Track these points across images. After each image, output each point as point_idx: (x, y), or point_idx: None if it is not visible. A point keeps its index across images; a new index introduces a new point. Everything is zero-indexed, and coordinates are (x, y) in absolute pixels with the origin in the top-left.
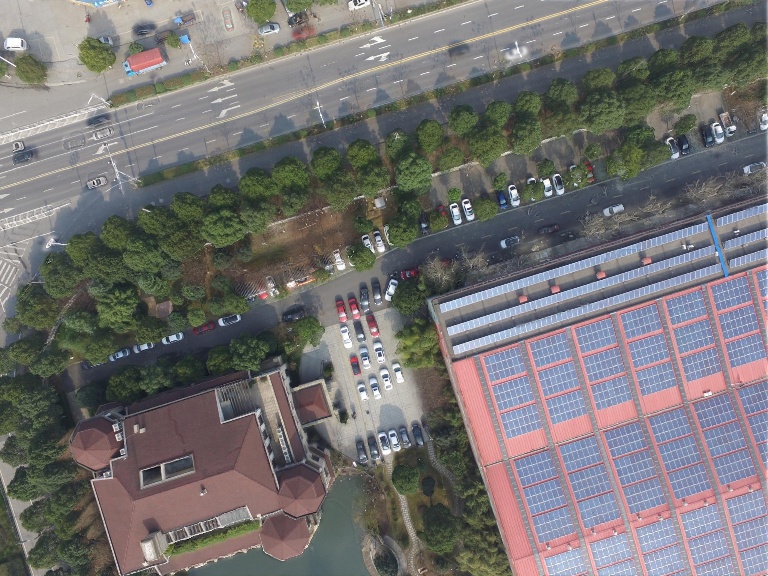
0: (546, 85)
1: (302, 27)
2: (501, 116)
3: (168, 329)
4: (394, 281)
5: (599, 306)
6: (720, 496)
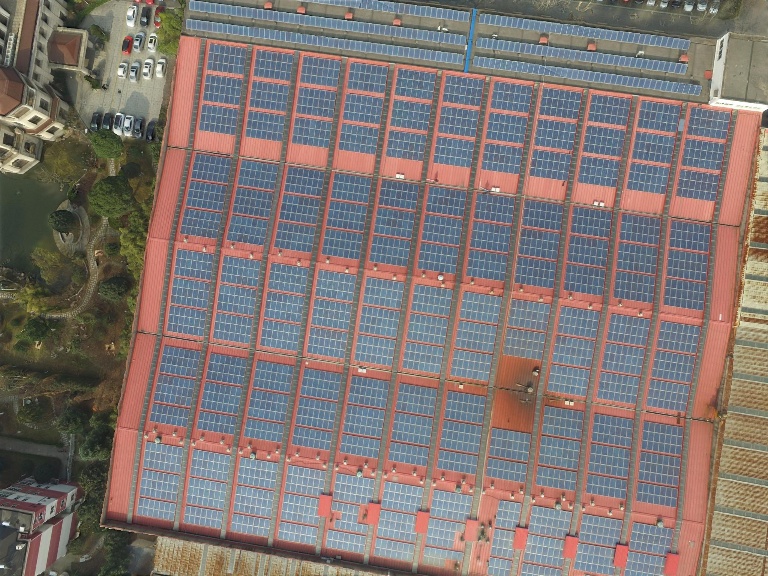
0: None
1: None
2: None
3: None
4: None
5: (335, 44)
6: (363, 270)
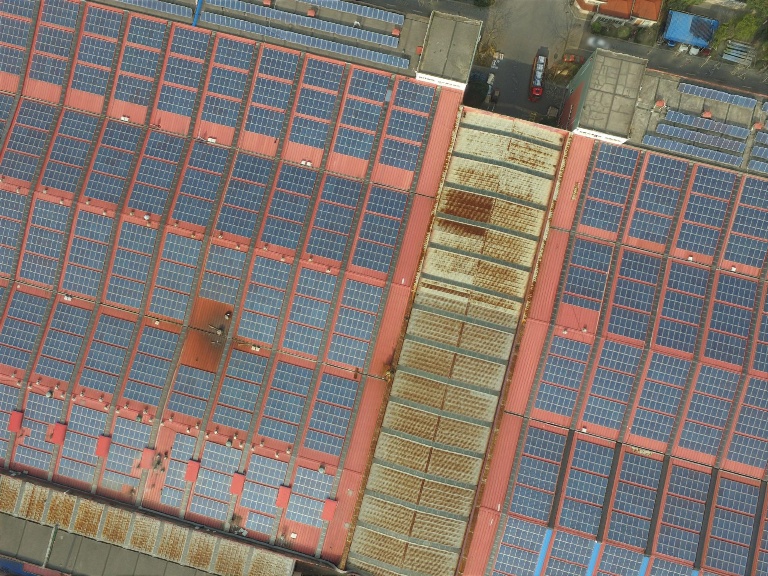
0: None
1: None
2: None
3: None
4: None
5: None
6: (77, 203)
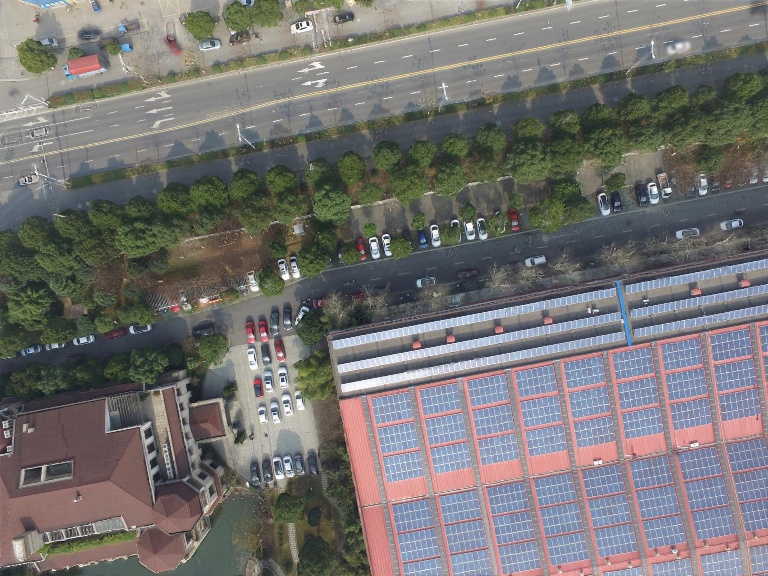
0: None
1: (243, 46)
2: (423, 156)
3: (77, 331)
4: (305, 308)
5: (494, 361)
6: (597, 568)
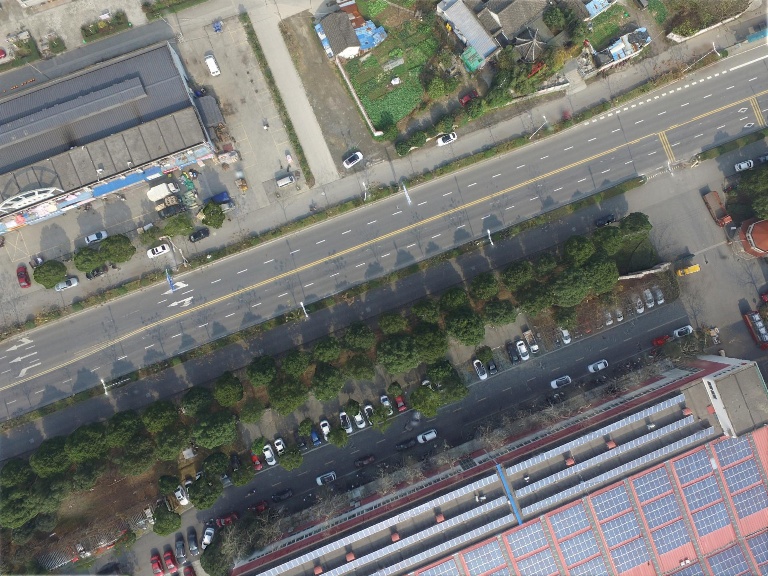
0: (352, 316)
1: (102, 277)
2: (295, 371)
3: None
4: (209, 531)
5: (396, 568)
6: None
